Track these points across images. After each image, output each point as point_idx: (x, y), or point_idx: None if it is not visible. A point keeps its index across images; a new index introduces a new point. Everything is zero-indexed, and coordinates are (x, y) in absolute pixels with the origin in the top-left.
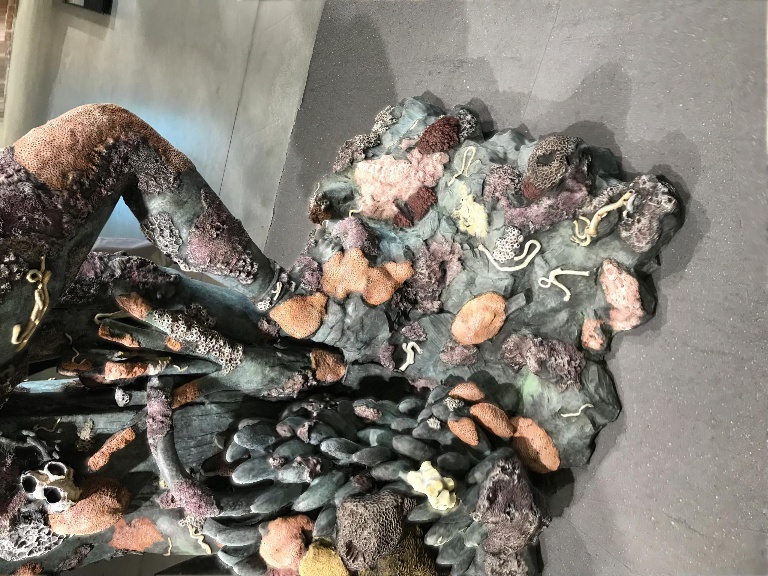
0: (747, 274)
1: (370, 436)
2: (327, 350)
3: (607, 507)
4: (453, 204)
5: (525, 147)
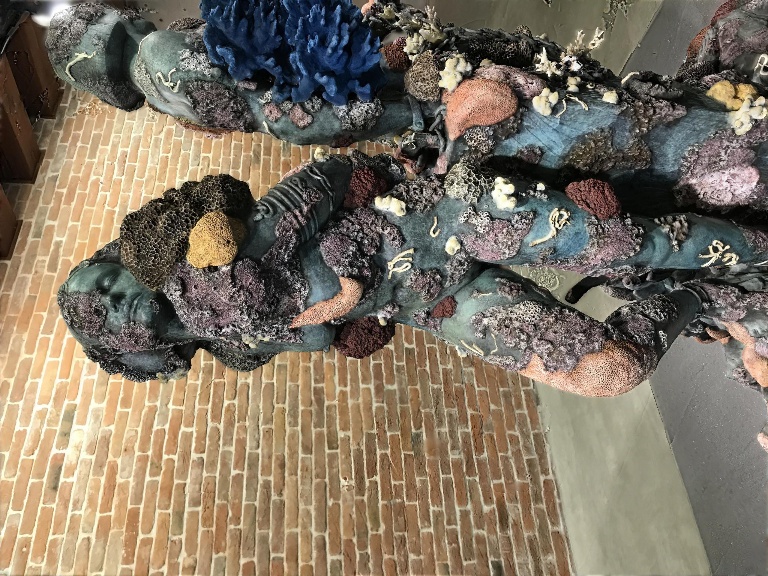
0: (766, 492)
1: (666, 285)
2: None
3: None
4: None
5: None
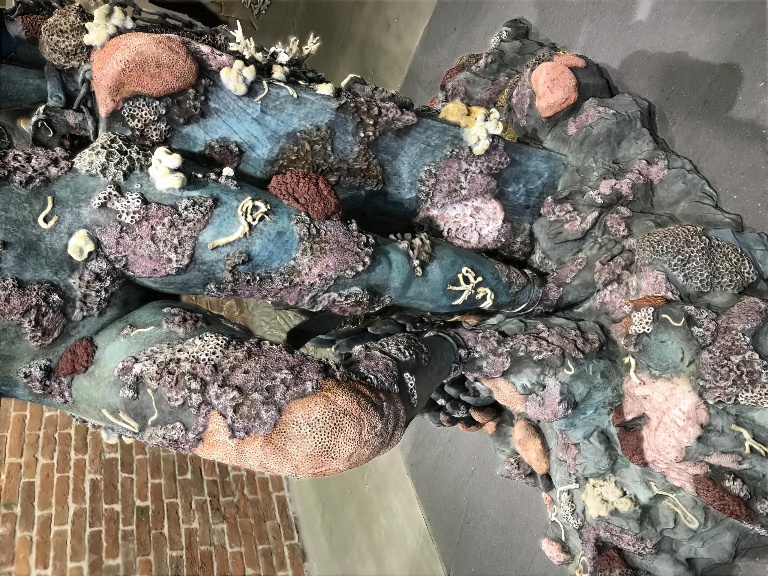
0: None
1: None
2: (480, 315)
3: (483, 430)
4: (625, 479)
5: (676, 574)
